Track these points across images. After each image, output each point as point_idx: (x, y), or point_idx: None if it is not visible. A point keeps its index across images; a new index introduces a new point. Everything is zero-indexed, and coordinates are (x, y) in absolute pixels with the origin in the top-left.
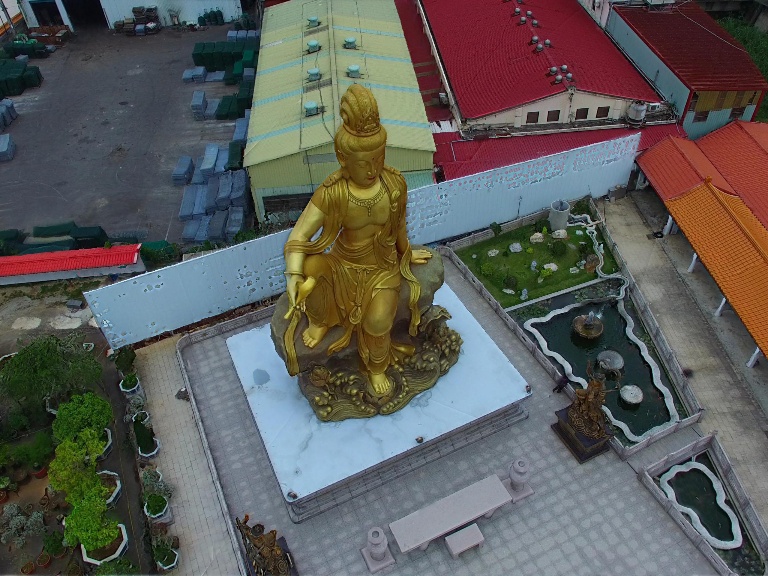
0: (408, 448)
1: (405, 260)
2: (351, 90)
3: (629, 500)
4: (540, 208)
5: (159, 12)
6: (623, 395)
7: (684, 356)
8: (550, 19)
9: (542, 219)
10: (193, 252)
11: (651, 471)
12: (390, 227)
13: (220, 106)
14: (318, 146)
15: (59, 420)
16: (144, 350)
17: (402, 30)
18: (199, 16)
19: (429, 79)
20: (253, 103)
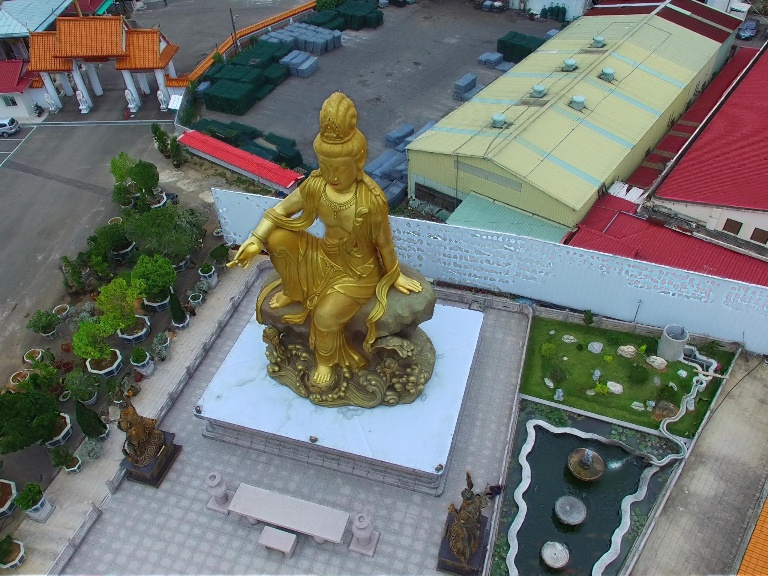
0: (300, 438)
1: (386, 280)
2: None
3: None
4: (666, 325)
5: None
6: (544, 548)
7: (660, 567)
8: None
9: None
10: None
11: None
12: (355, 238)
13: None
14: (468, 156)
15: None
16: None
17: (690, 80)
18: (544, 7)
19: None
20: (472, 98)
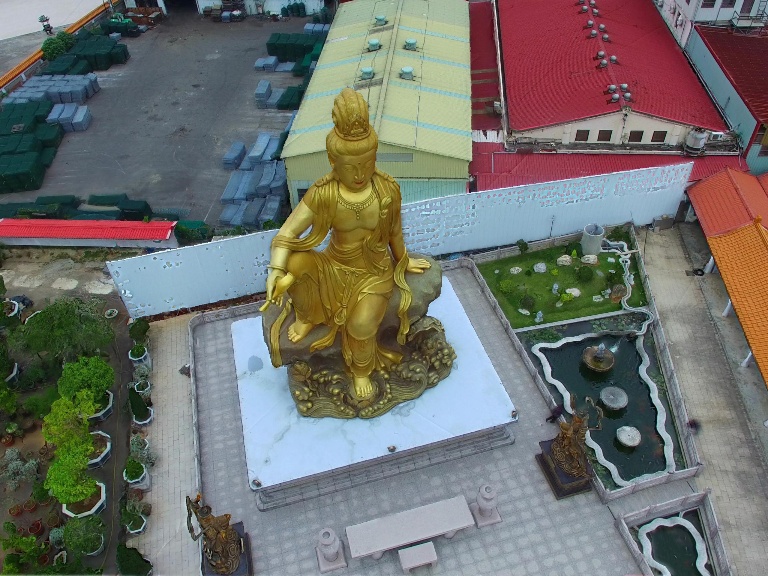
0: (379, 455)
1: (400, 267)
2: (342, 93)
3: (600, 546)
4: (575, 230)
5: (246, 1)
6: (619, 435)
7: (696, 404)
8: (625, 34)
9: (576, 241)
10: (225, 235)
11: (630, 519)
12: (380, 233)
13: (283, 96)
14: None
15: (64, 378)
16: (161, 323)
17: (469, 35)
18: (283, 7)
19: (489, 86)
20: (305, 96)
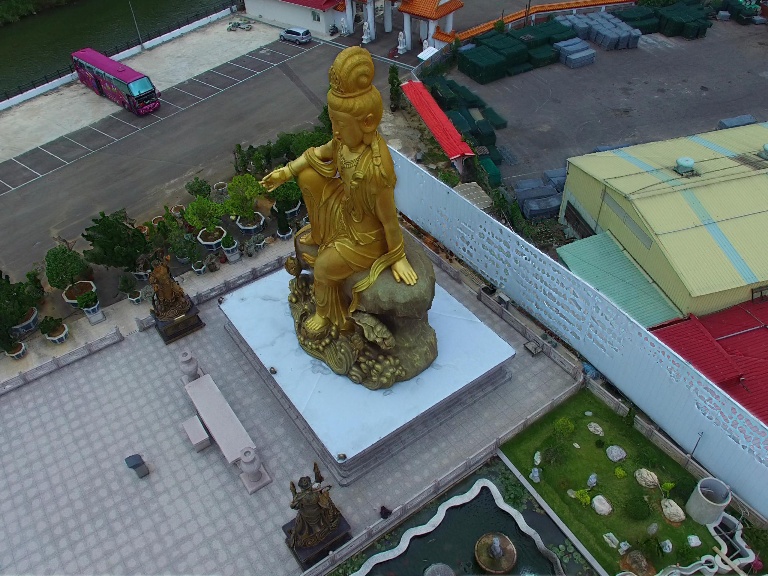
0: (266, 364)
1: (385, 259)
2: None
3: None
4: (726, 480)
5: None
6: None
7: None
8: None
9: None
10: (492, 191)
11: None
12: None
13: None
14: (613, 188)
15: None
16: None
17: None
18: None
19: None
20: (693, 135)
